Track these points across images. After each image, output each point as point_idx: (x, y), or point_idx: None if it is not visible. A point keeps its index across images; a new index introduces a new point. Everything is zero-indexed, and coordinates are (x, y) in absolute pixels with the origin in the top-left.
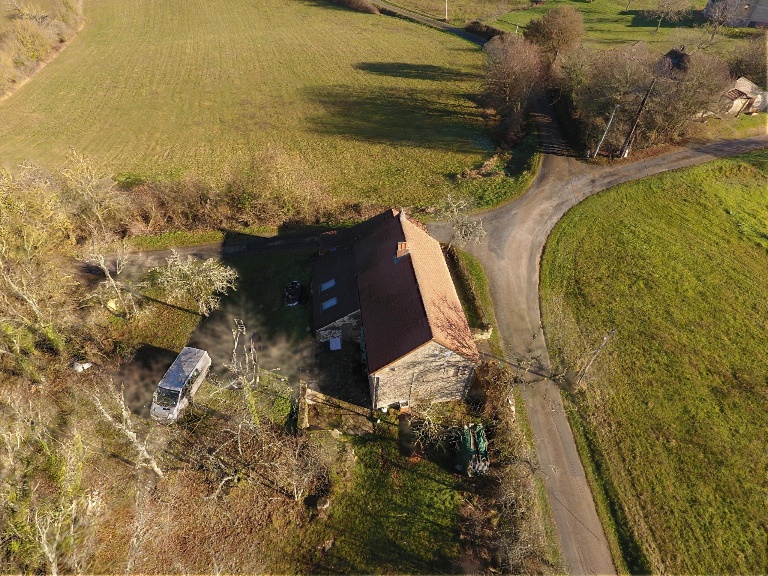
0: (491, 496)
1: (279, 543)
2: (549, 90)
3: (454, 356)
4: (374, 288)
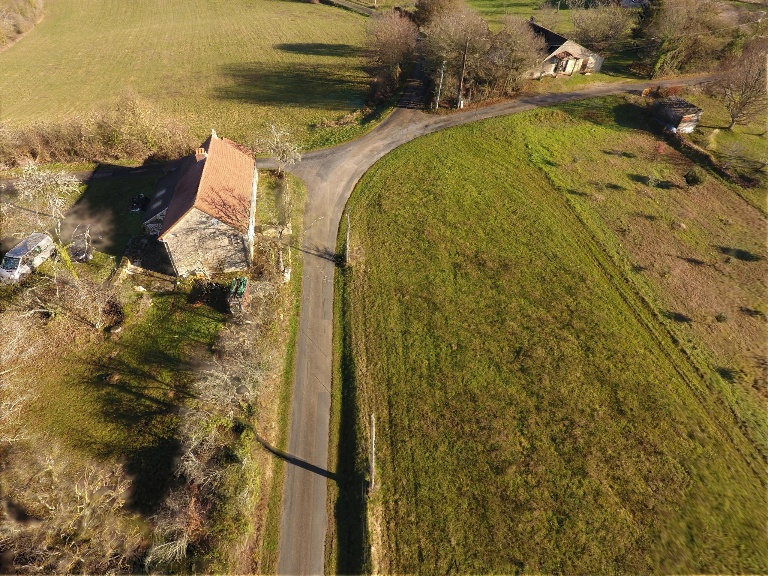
0: (244, 324)
1: (77, 353)
2: (415, 56)
3: (221, 224)
4: (181, 186)
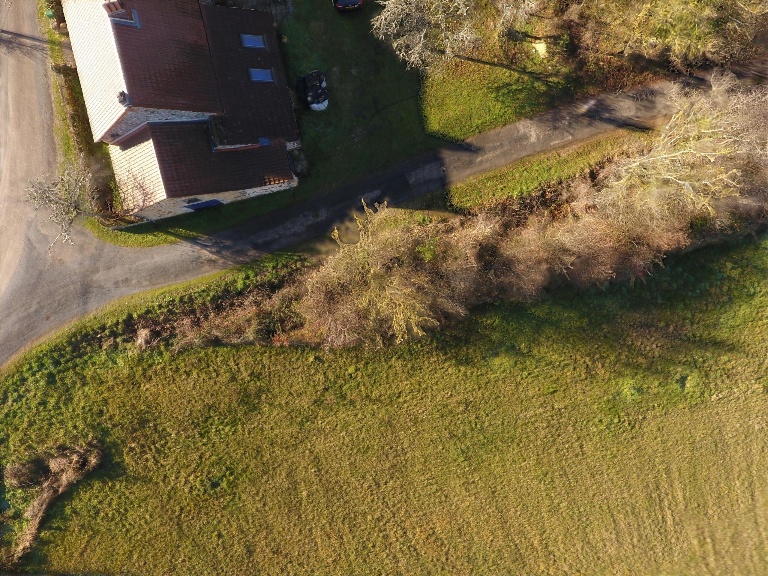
0: None
1: None
2: None
3: None
4: (174, 1)
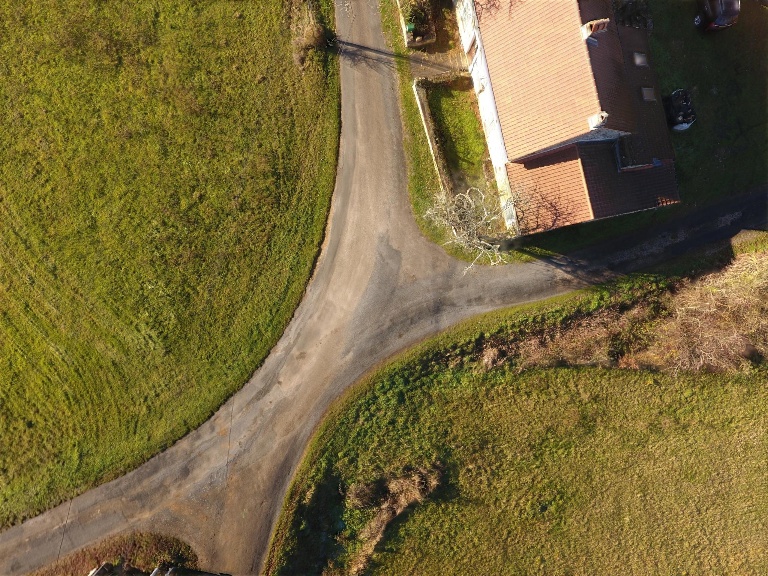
0: None
1: None
2: None
3: None
4: None
